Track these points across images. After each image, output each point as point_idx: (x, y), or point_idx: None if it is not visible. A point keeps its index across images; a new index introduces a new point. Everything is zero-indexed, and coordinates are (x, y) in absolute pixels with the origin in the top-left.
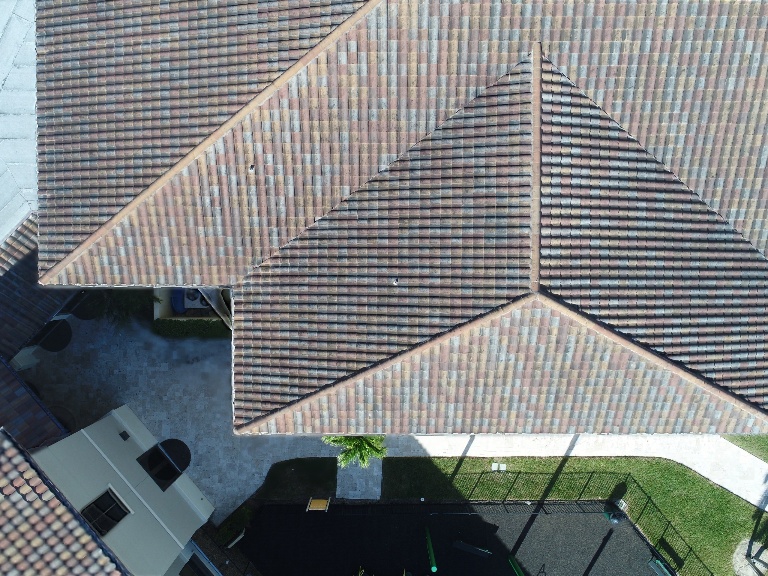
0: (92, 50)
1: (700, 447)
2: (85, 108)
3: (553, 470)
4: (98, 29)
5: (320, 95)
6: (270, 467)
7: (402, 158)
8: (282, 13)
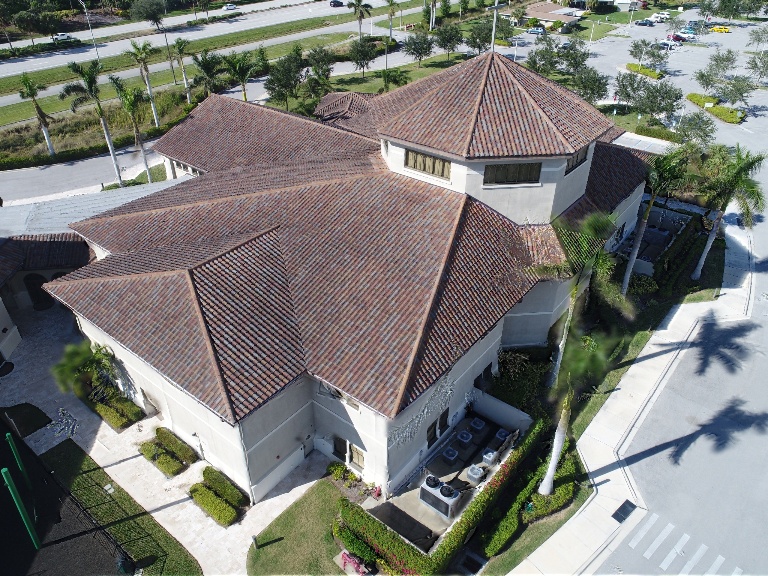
0: (169, 193)
1: (228, 575)
2: None
3: (132, 514)
4: None
5: None
6: (23, 403)
7: None
8: None
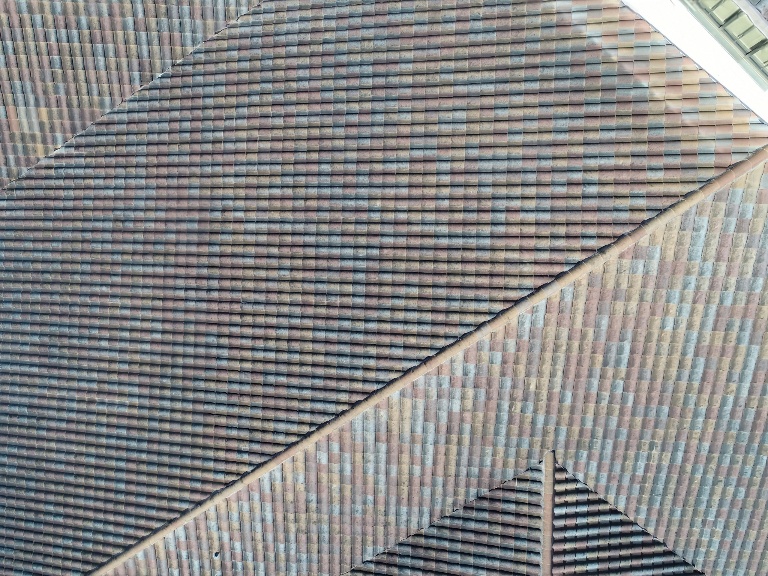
0: (42, 399)
1: None
2: (32, 463)
3: None
4: (49, 376)
5: (296, 489)
6: None
7: (390, 551)
8: (255, 399)
